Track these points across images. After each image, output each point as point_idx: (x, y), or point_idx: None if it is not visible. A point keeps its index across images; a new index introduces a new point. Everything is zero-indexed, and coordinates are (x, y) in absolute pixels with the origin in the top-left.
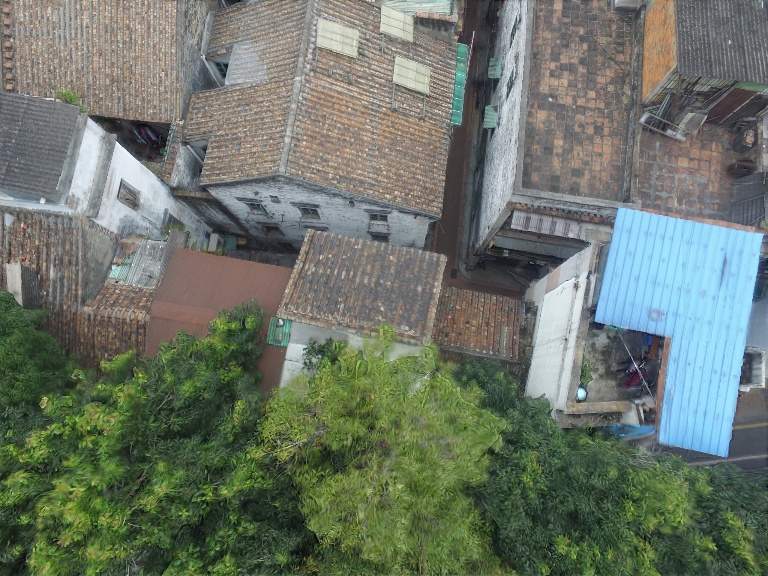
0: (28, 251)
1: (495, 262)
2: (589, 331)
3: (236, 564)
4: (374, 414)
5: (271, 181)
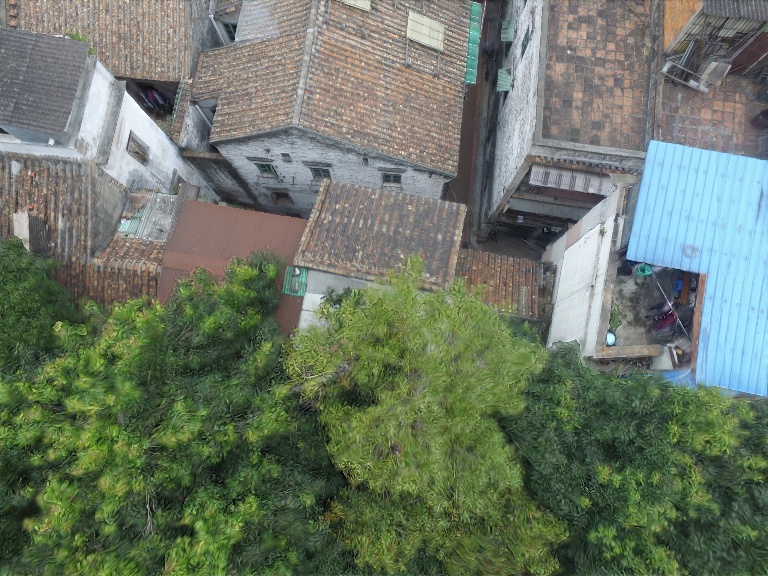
0: (36, 200)
1: (507, 234)
2: (616, 277)
3: (261, 496)
4: (406, 335)
5: (284, 135)
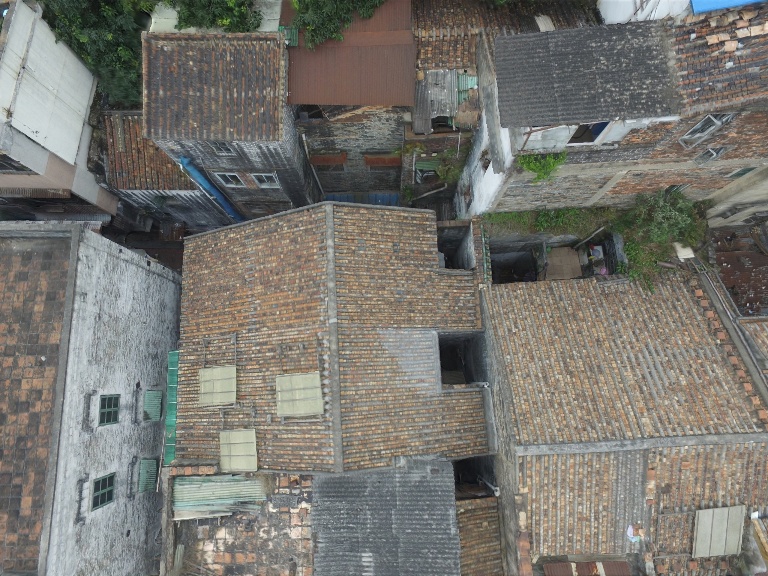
0: None
1: None
2: None
3: None
4: None
5: None
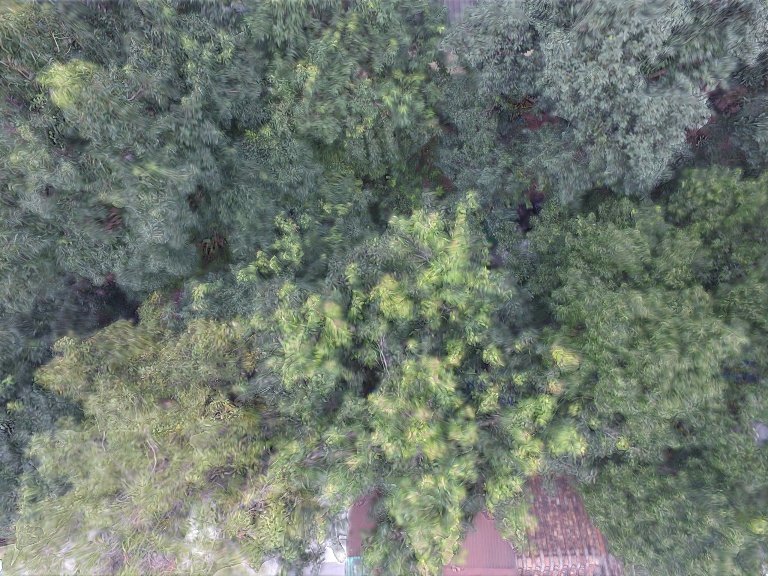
0: None
1: None
2: None
3: None
4: None
5: None
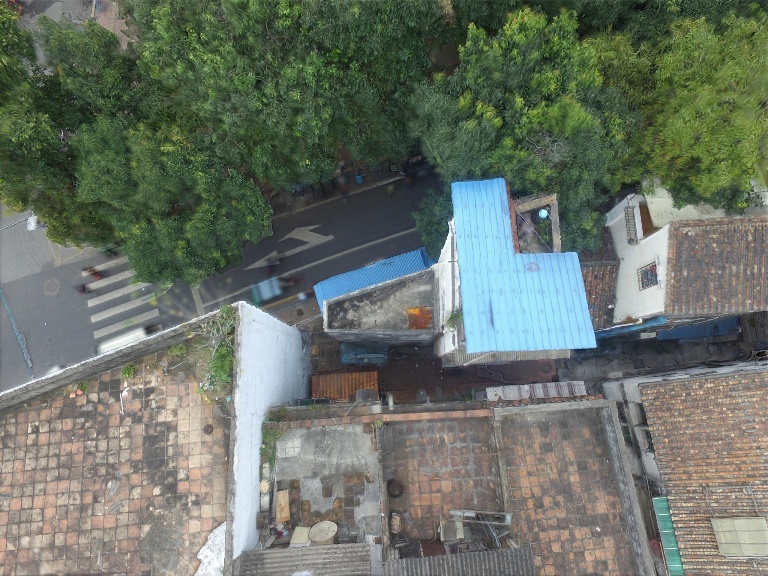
0: None
1: None
2: None
3: None
4: None
5: None
